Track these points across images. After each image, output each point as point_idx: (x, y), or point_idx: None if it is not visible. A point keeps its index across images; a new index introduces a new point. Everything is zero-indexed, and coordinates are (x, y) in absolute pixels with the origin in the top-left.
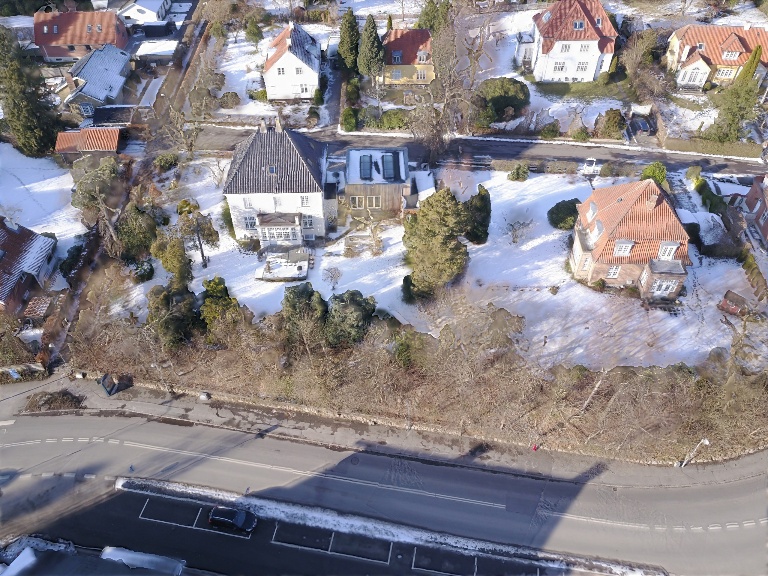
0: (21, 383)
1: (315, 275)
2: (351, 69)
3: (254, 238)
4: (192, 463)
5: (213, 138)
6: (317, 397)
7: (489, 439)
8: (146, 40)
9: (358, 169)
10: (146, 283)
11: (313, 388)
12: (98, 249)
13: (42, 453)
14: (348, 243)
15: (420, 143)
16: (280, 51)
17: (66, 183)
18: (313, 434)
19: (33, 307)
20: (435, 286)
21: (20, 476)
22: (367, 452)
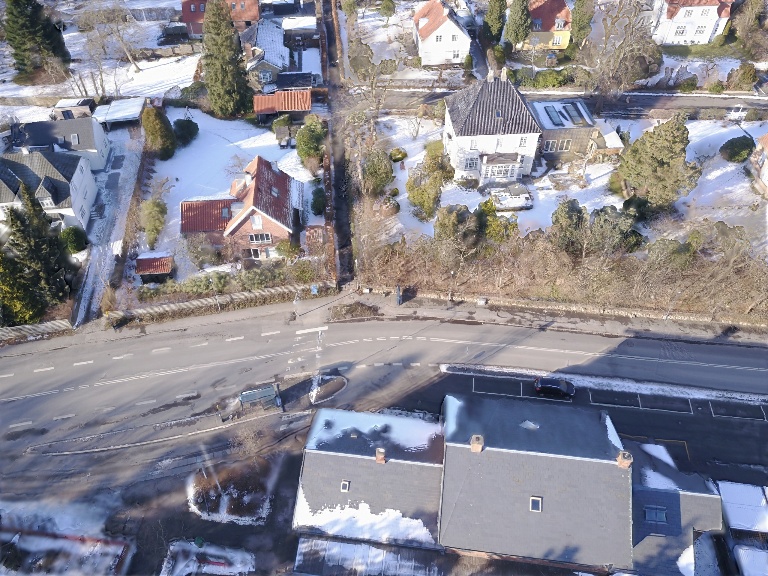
0: (317, 299)
1: (539, 205)
2: (495, 36)
3: (469, 178)
4: (497, 351)
5: (386, 99)
6: (582, 297)
7: (736, 323)
8: (276, 18)
9: (547, 117)
10: (397, 215)
11: (576, 290)
12: (351, 187)
13: (365, 349)
14: (553, 179)
15: (577, 98)
16: (436, 20)
17: (270, 140)
18: (586, 326)
19: (311, 236)
20: (672, 202)
21: (356, 367)
22: (637, 337)
